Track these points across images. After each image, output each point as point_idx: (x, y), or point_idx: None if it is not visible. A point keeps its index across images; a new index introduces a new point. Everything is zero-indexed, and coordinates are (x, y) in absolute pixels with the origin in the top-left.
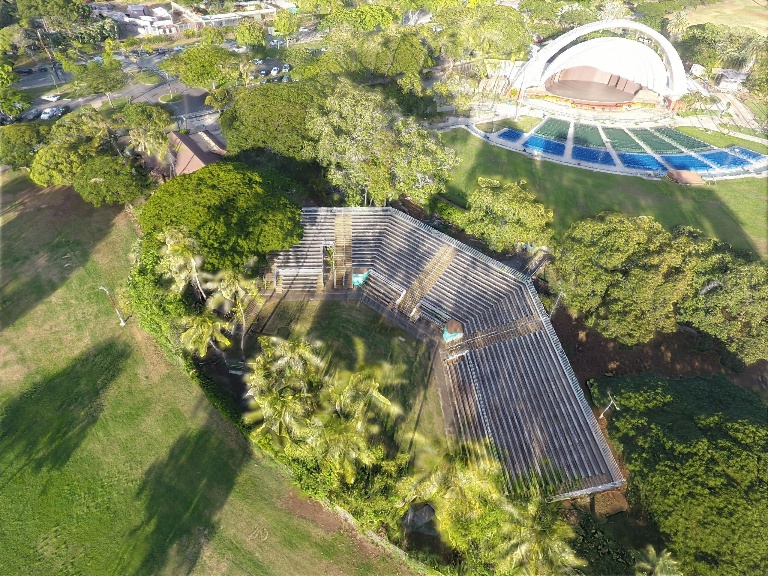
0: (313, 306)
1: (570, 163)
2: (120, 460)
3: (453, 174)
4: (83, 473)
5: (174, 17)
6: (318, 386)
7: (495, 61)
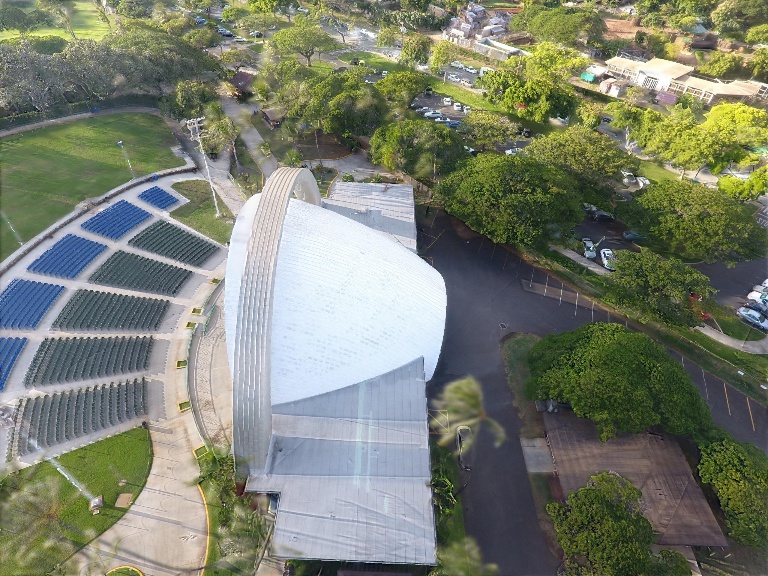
0: None
1: (59, 230)
2: None
3: (62, 143)
4: None
5: None
6: None
7: (399, 192)
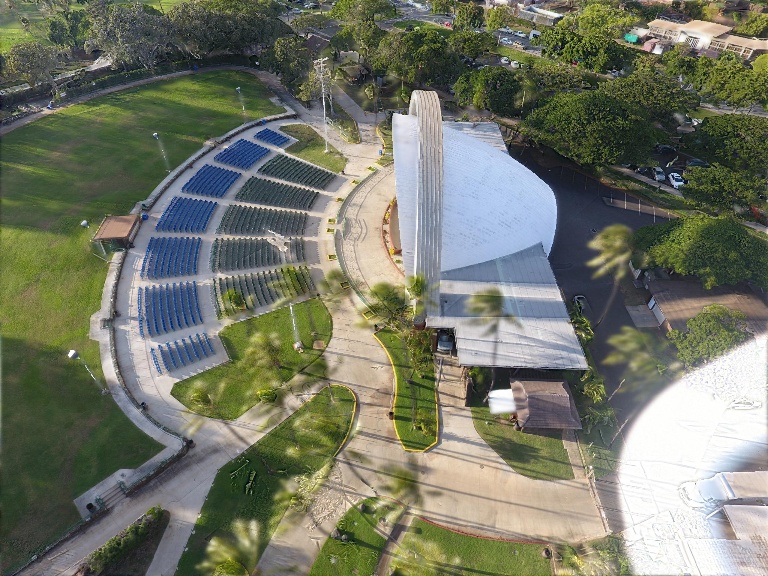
0: None
1: (196, 162)
2: None
3: (175, 94)
4: None
5: None
6: (8, 67)
7: (487, 128)
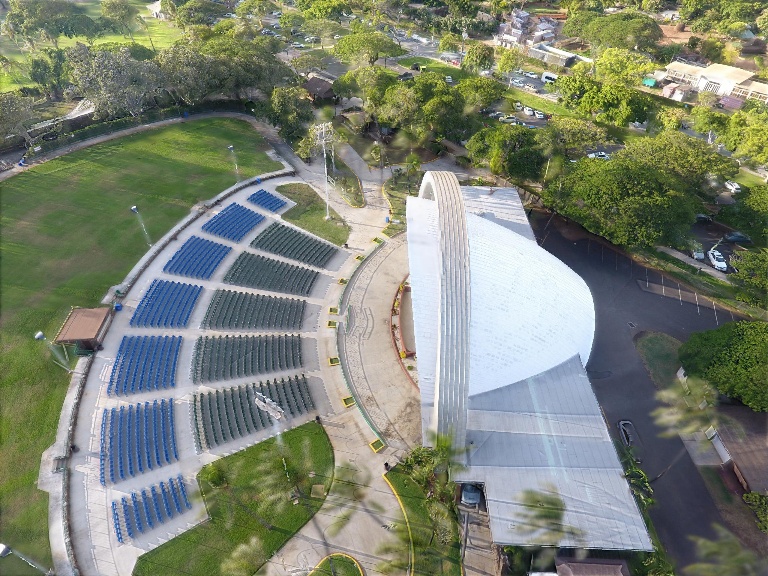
0: (58, 116)
1: (181, 232)
2: (2, 90)
3: (162, 147)
4: (3, 86)
5: (558, 44)
6: None
7: (506, 195)
